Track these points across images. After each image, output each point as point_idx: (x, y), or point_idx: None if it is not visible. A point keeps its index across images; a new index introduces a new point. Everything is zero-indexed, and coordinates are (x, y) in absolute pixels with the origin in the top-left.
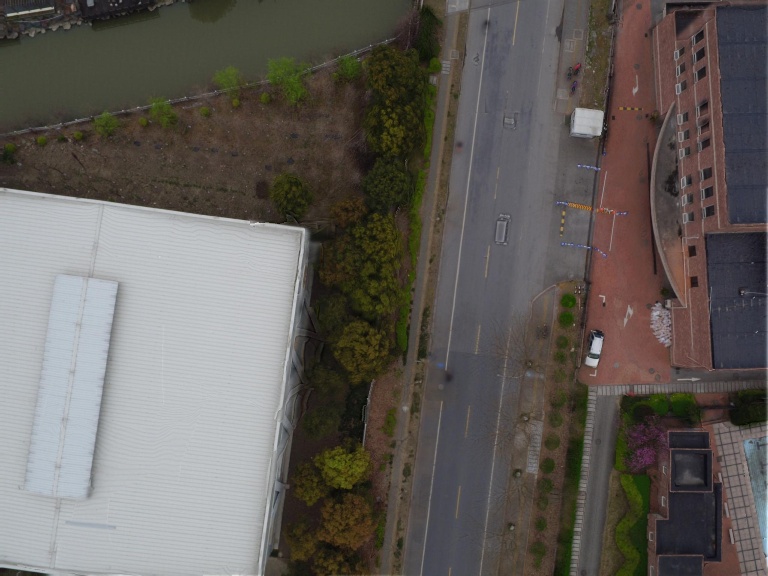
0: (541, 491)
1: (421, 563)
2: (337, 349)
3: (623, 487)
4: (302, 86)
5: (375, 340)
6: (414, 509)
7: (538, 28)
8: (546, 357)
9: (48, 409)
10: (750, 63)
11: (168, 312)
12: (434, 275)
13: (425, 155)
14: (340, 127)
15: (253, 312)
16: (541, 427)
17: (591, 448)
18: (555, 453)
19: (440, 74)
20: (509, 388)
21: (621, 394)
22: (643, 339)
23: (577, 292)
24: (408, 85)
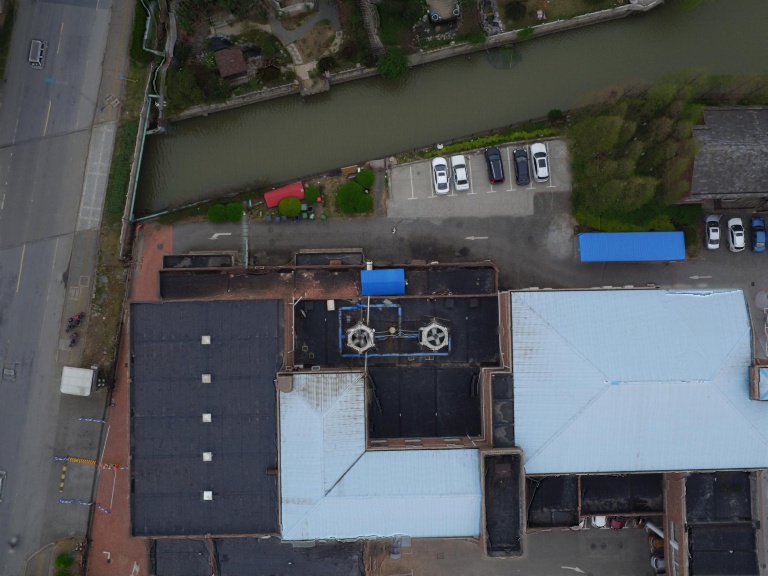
0: None
1: None
2: None
3: None
4: None
5: None
6: None
7: (44, 274)
8: None
9: None
10: (166, 363)
11: None
12: None
13: None
14: None
15: None
16: None
17: None
18: None
19: None
20: None
21: None
22: None
23: (78, 549)
24: None
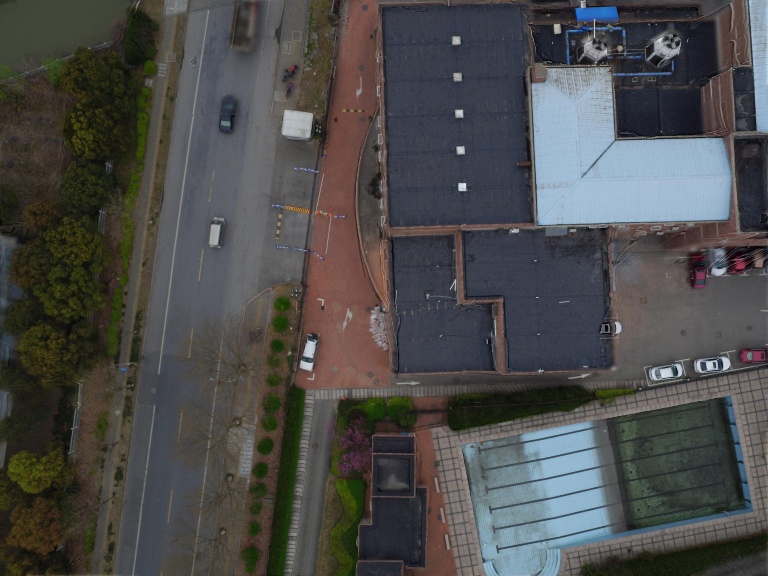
0: (254, 496)
1: (132, 567)
2: (21, 353)
3: (338, 492)
4: (21, 89)
5: (56, 344)
6: (125, 513)
7: (257, 30)
8: (260, 361)
9: None
10: (417, 65)
11: None
12: (147, 278)
13: (138, 158)
14: (58, 130)
15: None
16: (253, 431)
17: (308, 452)
18: (270, 457)
19: (156, 77)
20: (222, 392)
21: (339, 398)
22: (362, 343)
23: (294, 295)
24: (102, 88)
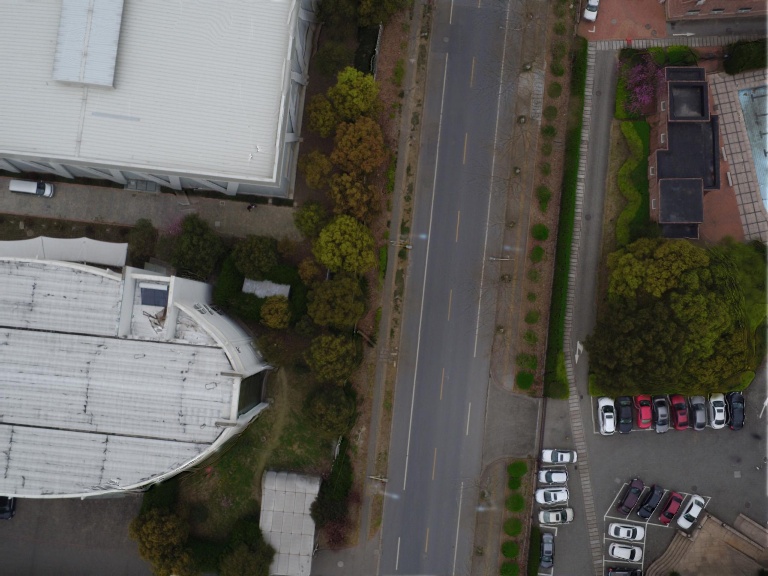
0: (545, 137)
1: (431, 207)
2: None
3: (624, 134)
4: None
5: None
6: (423, 155)
7: None
8: (546, 10)
9: (68, 52)
10: None
11: None
12: None
13: None
14: None
15: None
16: (543, 75)
17: (592, 99)
18: (557, 103)
19: None
20: (511, 39)
21: (619, 48)
22: None
23: None
24: None
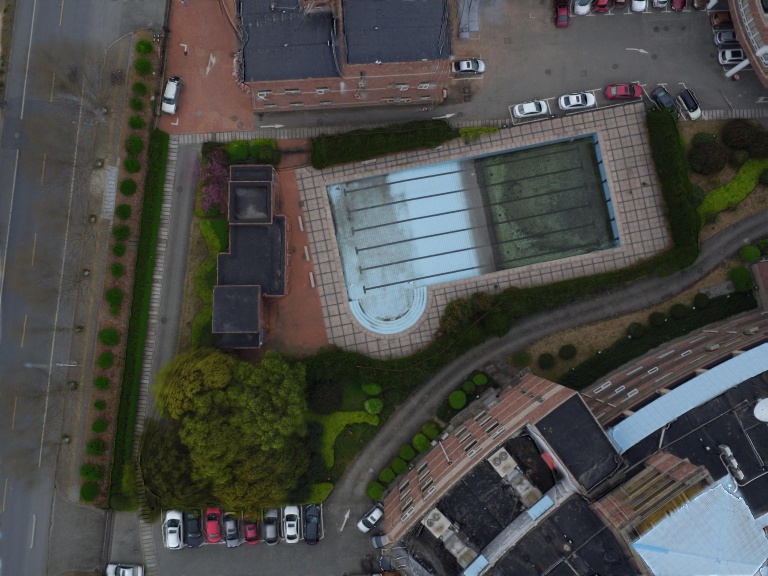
0: (118, 237)
1: None
2: None
3: (202, 232)
4: None
5: None
6: None
7: None
8: (122, 104)
9: None
10: None
11: None
12: (8, 24)
13: None
14: None
15: None
16: (116, 172)
17: (172, 196)
18: (133, 200)
19: None
20: (84, 135)
21: (203, 142)
22: (226, 87)
23: (156, 40)
24: None
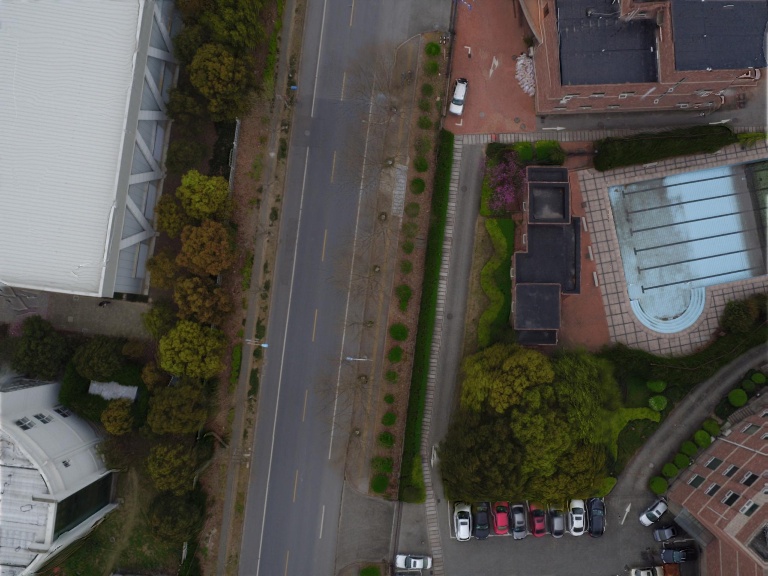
0: (406, 235)
1: (288, 305)
2: (192, 72)
3: (488, 231)
4: None
5: (228, 60)
6: (281, 252)
7: None
8: (411, 104)
9: None
10: None
11: (17, 19)
12: (300, 24)
13: None
14: None
15: (101, 21)
16: (406, 171)
17: (457, 195)
18: (421, 198)
19: None
20: (374, 133)
21: (487, 142)
22: (508, 89)
23: (442, 42)
24: None
